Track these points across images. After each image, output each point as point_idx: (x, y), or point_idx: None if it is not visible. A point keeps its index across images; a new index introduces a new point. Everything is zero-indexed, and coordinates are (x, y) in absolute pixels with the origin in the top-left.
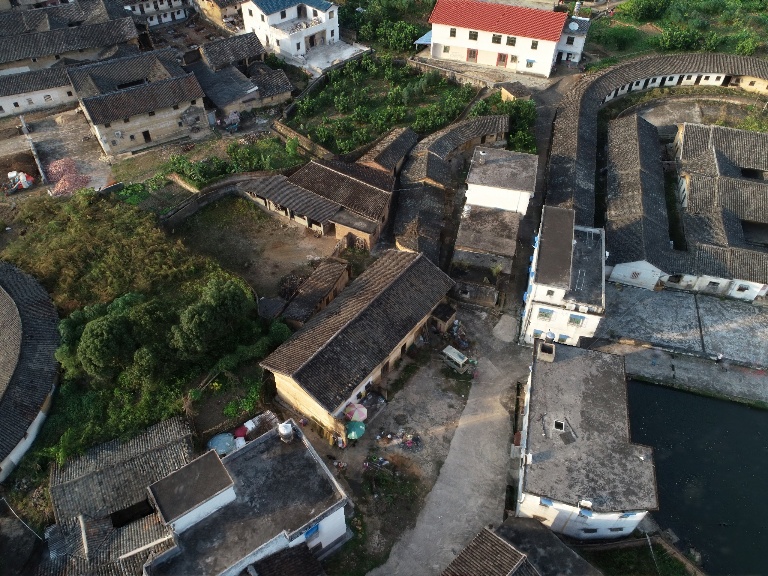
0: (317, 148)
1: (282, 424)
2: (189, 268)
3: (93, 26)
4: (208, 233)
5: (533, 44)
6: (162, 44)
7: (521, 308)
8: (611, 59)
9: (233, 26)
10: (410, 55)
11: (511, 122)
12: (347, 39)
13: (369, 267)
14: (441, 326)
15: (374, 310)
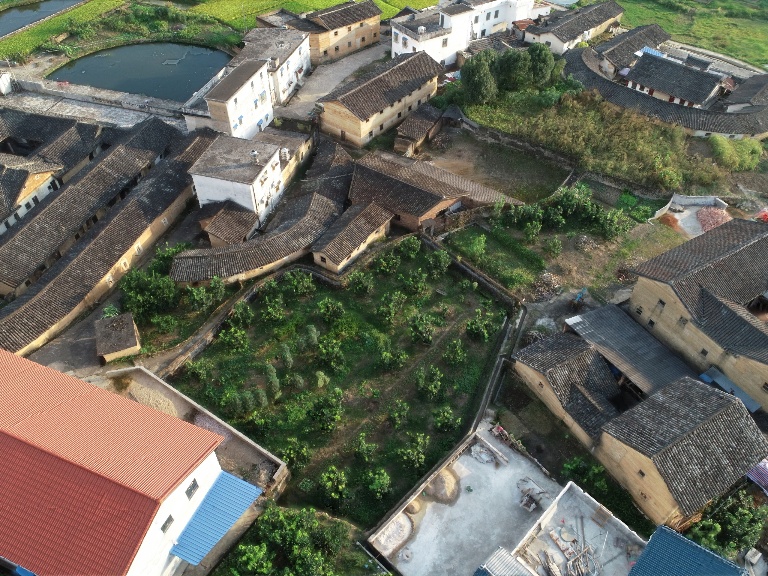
0: None
1: (423, 27)
2: None
3: None
4: None
5: None
6: None
7: None
8: None
9: None
10: None
11: None
12: None
13: (380, 110)
14: None
15: None
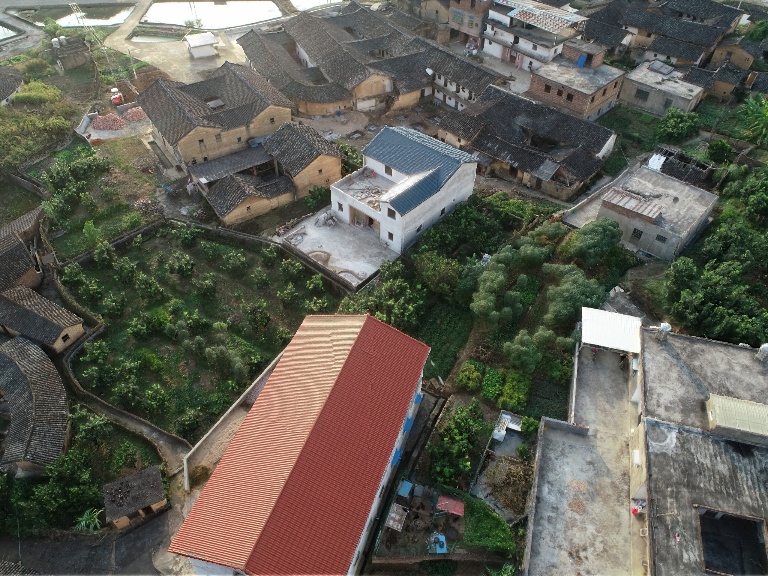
0: None
1: None
2: None
3: (352, 59)
4: (1, 206)
5: None
6: (394, 118)
7: None
8: None
9: None
10: None
11: None
12: None
13: None
14: None
15: None
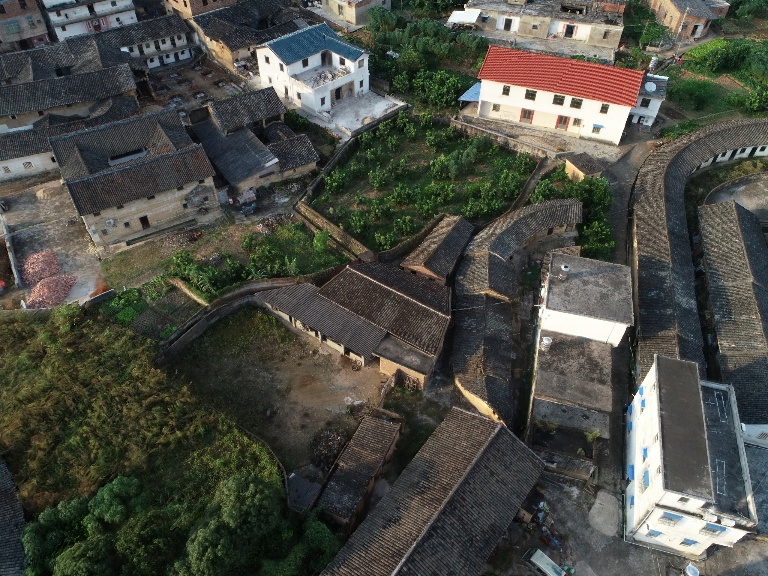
0: (351, 241)
1: None
2: (197, 430)
3: (83, 76)
4: (220, 362)
5: (603, 107)
6: (164, 92)
7: (621, 481)
8: (690, 123)
9: (246, 71)
10: (453, 112)
11: (582, 207)
12: (378, 90)
13: (431, 436)
14: (524, 516)
15: (446, 519)
